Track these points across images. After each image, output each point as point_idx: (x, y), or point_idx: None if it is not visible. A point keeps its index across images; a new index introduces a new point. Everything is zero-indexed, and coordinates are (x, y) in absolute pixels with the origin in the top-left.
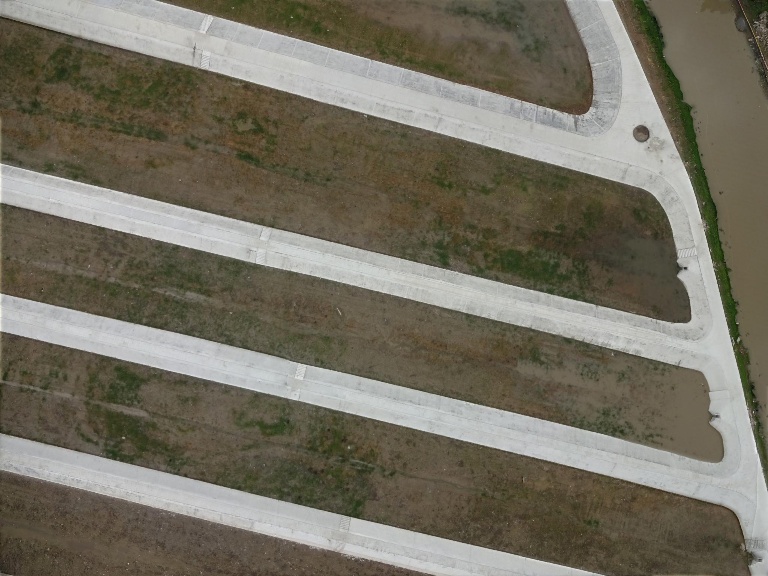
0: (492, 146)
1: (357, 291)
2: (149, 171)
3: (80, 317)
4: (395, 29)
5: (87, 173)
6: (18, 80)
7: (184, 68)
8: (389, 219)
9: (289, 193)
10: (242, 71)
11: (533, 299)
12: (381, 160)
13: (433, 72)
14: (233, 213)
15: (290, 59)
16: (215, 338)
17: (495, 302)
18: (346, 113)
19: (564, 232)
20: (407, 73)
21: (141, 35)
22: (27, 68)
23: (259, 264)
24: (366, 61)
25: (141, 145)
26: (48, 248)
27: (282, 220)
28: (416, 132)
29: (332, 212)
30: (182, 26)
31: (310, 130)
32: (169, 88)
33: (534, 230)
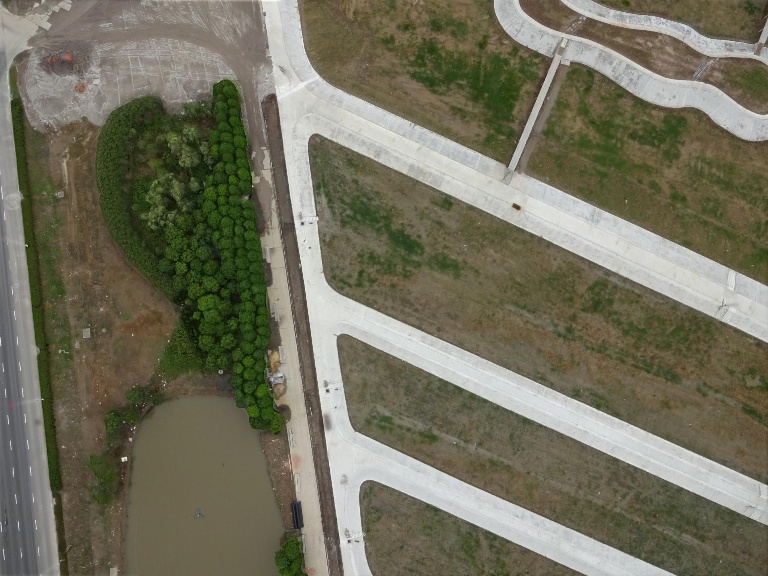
0: None
1: None
2: (664, 411)
3: (588, 543)
4: None
5: (609, 404)
6: (558, 304)
7: (706, 318)
8: None
9: None
10: (760, 330)
11: None
12: None
13: None
14: (733, 464)
15: None
16: None
17: None
18: None
19: None
20: None
21: (677, 283)
22: (567, 294)
23: (752, 519)
24: None
25: (659, 385)
26: (566, 470)
27: None
28: None
29: None
30: (713, 280)
31: None
32: (690, 334)
33: None
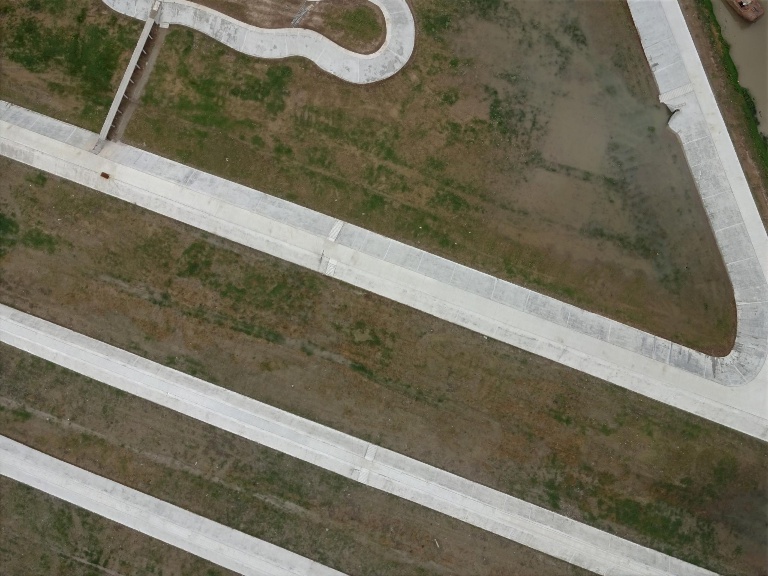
0: (618, 383)
1: (458, 524)
2: (264, 373)
3: (182, 515)
4: (525, 247)
5: (205, 370)
6: (154, 271)
7: (309, 272)
8: (499, 450)
9: (399, 411)
10: (366, 281)
11: (649, 560)
12: (497, 386)
13: (561, 296)
14: (341, 425)
15: (415, 274)
16: (308, 554)
17: (606, 558)
18: (466, 332)
19: (690, 487)
20: (534, 296)
21: (272, 238)
22: (163, 260)
23: (361, 482)
24: (492, 279)
25: (259, 346)
26: (160, 440)
27: (389, 438)
28: (537, 360)
29: (440, 436)
30: (313, 232)
31: (427, 347)
32: (293, 291)
33: (656, 480)
